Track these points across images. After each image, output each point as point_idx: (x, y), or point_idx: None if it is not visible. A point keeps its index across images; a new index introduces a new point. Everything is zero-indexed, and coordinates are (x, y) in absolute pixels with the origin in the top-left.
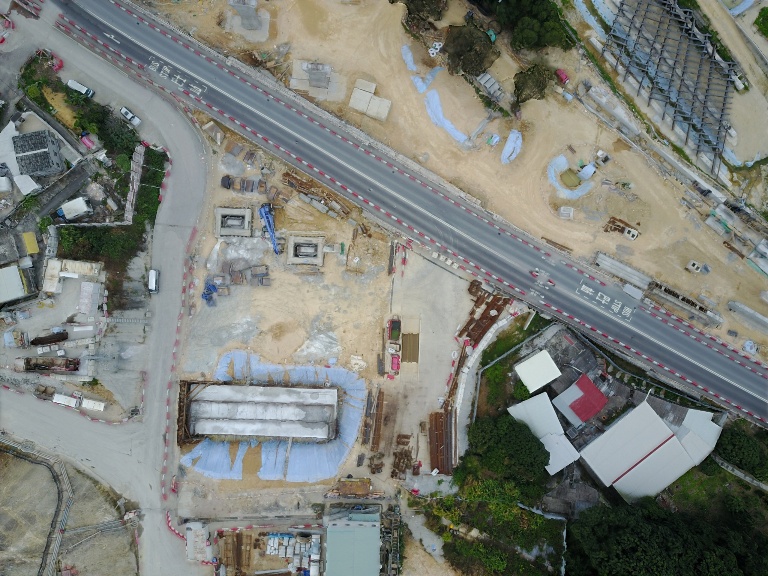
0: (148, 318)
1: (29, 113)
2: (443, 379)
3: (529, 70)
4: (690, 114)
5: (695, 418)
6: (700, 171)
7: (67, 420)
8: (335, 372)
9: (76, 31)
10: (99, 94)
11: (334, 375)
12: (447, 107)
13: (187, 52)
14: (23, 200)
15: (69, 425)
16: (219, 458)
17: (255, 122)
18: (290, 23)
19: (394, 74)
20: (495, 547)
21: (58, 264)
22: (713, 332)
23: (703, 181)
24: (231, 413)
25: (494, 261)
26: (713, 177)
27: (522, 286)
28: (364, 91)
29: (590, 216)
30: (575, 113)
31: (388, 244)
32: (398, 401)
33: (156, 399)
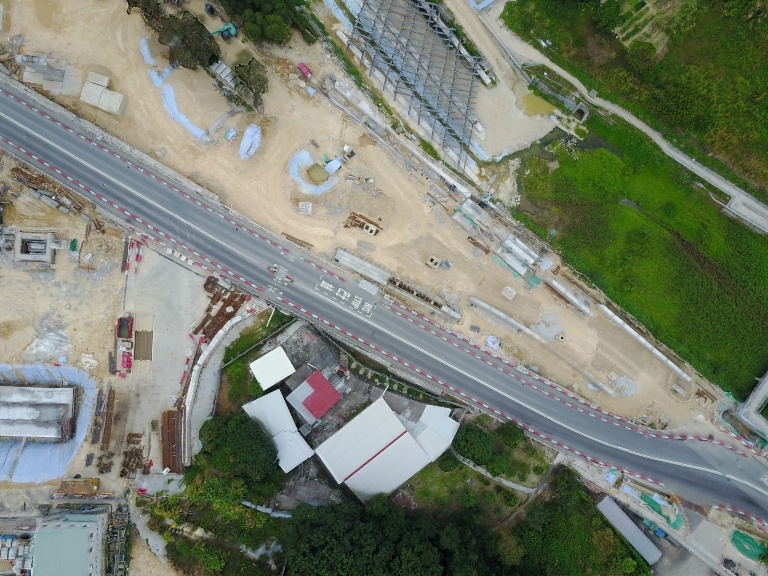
0: None
1: None
2: (177, 377)
3: (249, 63)
4: (436, 108)
5: (432, 414)
6: (444, 166)
7: None
8: (67, 370)
9: None
10: None
11: (67, 373)
12: (182, 101)
13: None
14: None
15: None
16: None
17: None
18: (22, 15)
19: (131, 67)
20: (216, 546)
21: None
22: (455, 328)
23: (448, 176)
24: None
25: (231, 257)
26: (461, 172)
27: (260, 282)
28: (96, 84)
29: (331, 211)
30: (319, 107)
31: (122, 240)
32: (130, 399)
33: None
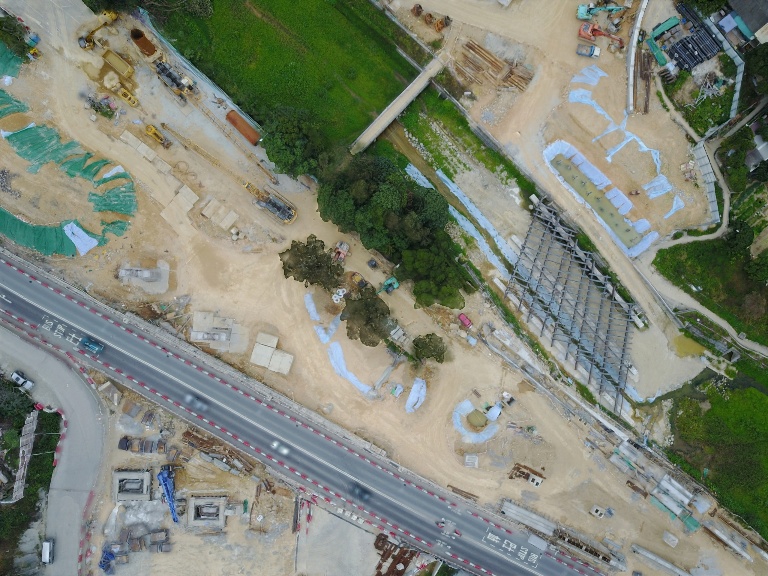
0: None
1: None
2: None
3: (427, 336)
4: (592, 354)
5: None
6: (602, 412)
7: None
8: None
9: None
10: None
11: None
12: (350, 360)
13: (82, 310)
14: None
15: None
16: None
17: (154, 379)
18: (190, 275)
19: (297, 324)
20: None
21: None
22: (618, 574)
23: (606, 421)
24: None
25: (400, 513)
26: (616, 414)
27: (428, 537)
28: (266, 346)
29: (495, 462)
30: (479, 356)
31: (292, 500)
32: None
33: None
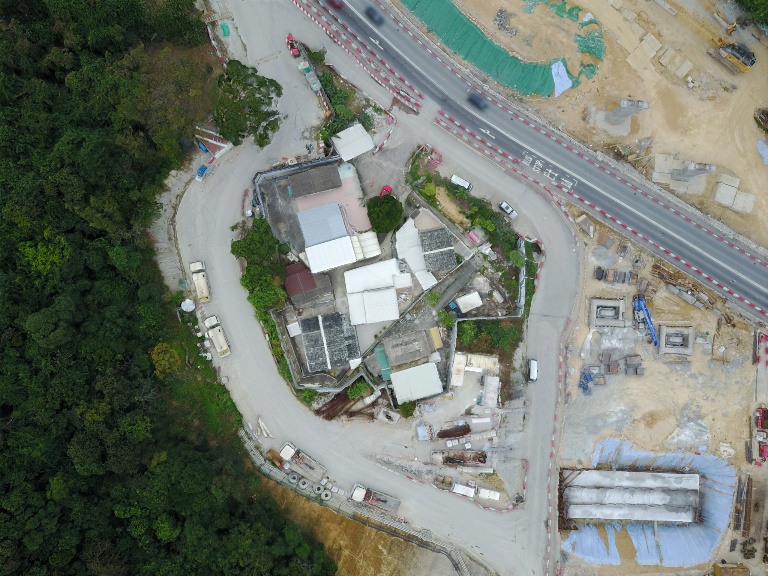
0: (526, 406)
1: (423, 209)
2: None
3: None
4: None
5: None
6: None
7: (460, 508)
8: (703, 458)
9: (454, 127)
10: (475, 187)
11: (699, 461)
12: None
13: (559, 147)
14: (420, 294)
15: (462, 513)
16: (592, 542)
17: (623, 215)
18: (653, 119)
19: (752, 168)
20: None
21: (464, 359)
22: None
23: None
24: (599, 498)
25: None
26: None
27: None
28: (729, 186)
29: None
30: None
31: (751, 334)
32: (766, 487)
33: (536, 486)
